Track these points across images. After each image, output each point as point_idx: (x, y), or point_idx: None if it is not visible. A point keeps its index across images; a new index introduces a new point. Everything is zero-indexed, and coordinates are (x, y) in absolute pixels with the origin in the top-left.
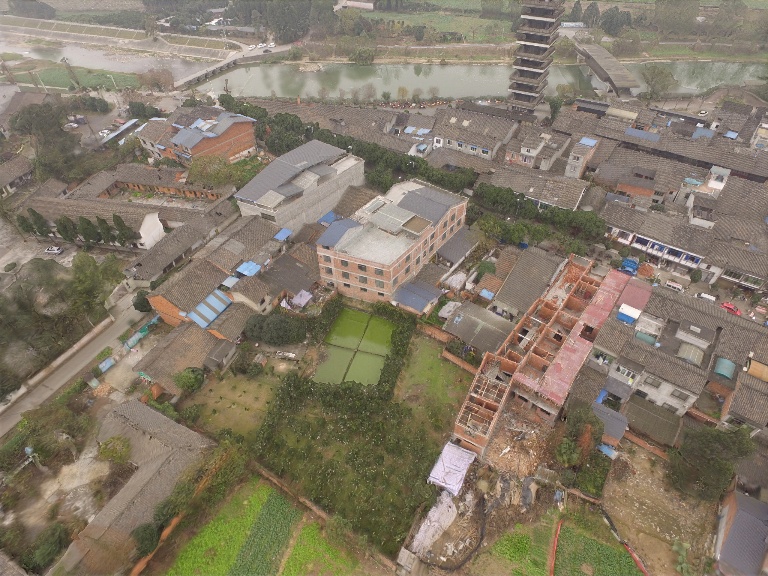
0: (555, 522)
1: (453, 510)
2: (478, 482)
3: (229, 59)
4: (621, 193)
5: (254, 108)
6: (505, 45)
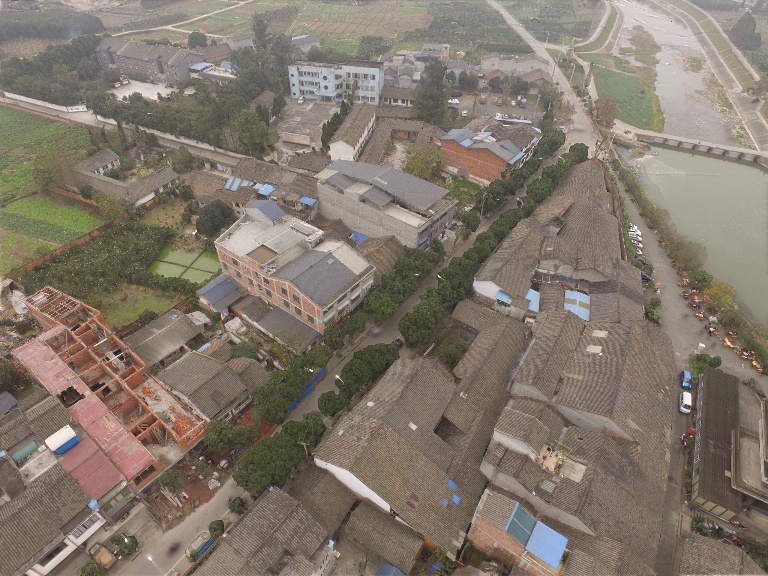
0: None
1: (22, 312)
2: (35, 332)
3: (755, 151)
4: None
5: None
6: None
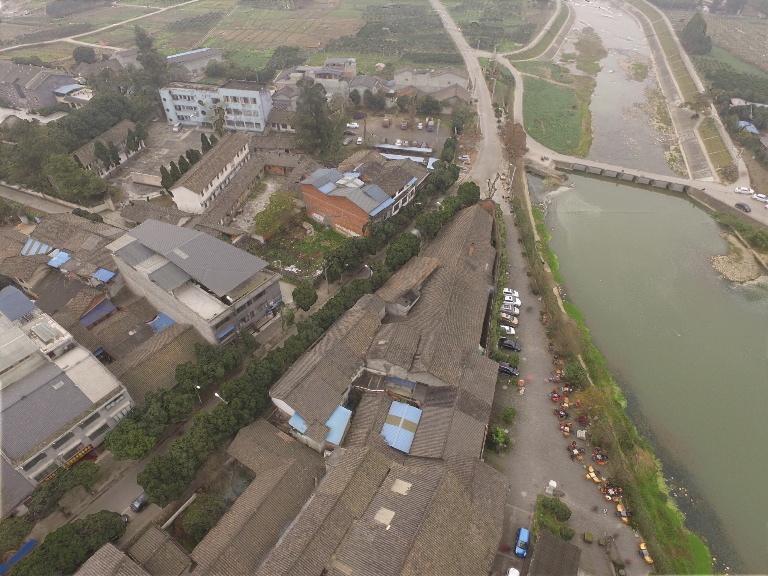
0: None
1: None
2: None
3: (684, 180)
4: None
5: None
6: None
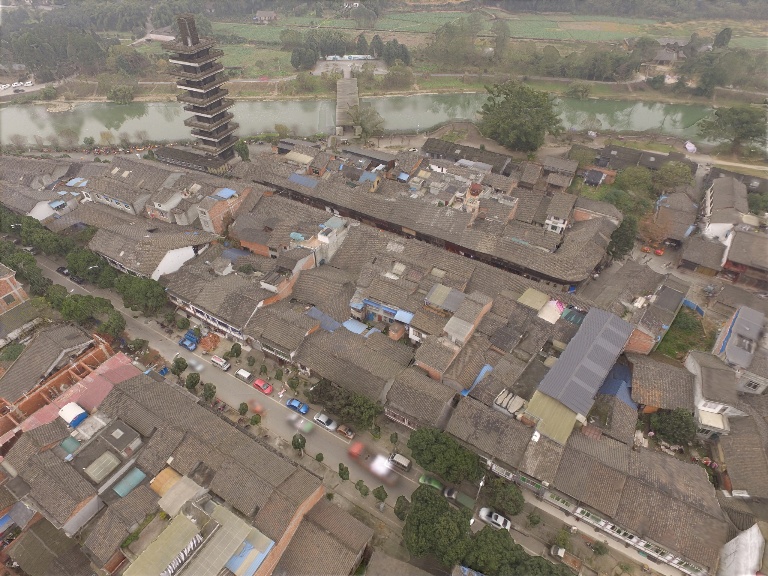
0: None
1: None
2: None
3: None
4: (245, 249)
5: None
6: (277, 80)
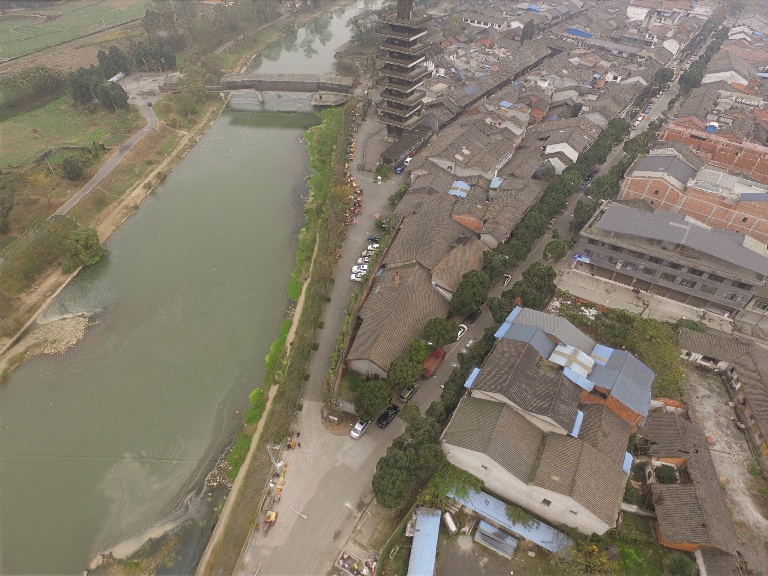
0: None
1: None
2: None
3: None
4: (543, 118)
5: (435, 332)
6: (152, 123)
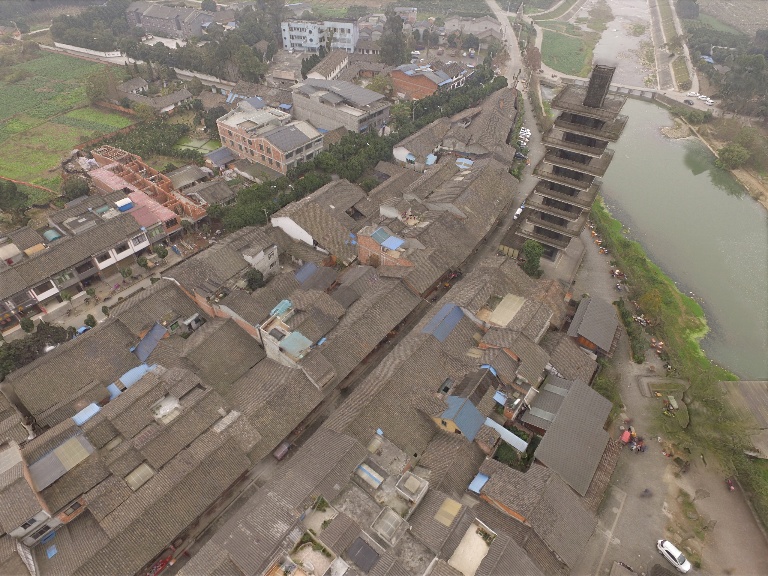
0: (56, 192)
1: None
2: None
3: (653, 90)
4: None
5: None
6: None
